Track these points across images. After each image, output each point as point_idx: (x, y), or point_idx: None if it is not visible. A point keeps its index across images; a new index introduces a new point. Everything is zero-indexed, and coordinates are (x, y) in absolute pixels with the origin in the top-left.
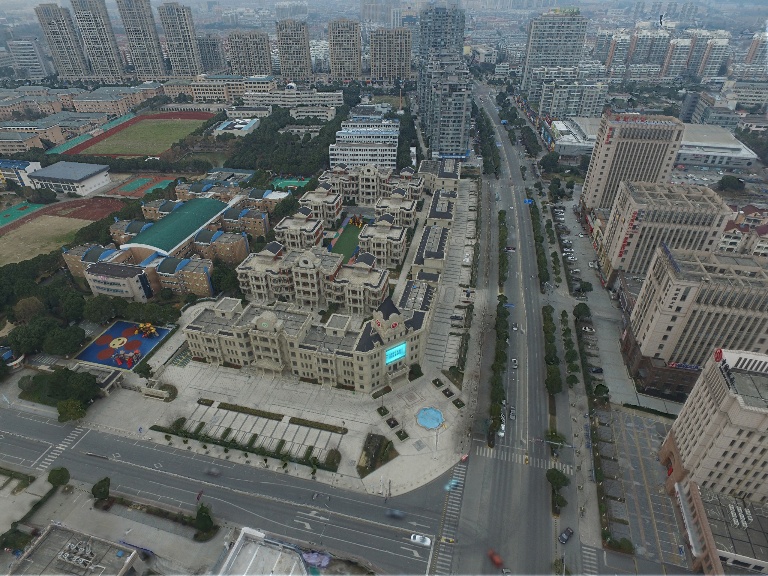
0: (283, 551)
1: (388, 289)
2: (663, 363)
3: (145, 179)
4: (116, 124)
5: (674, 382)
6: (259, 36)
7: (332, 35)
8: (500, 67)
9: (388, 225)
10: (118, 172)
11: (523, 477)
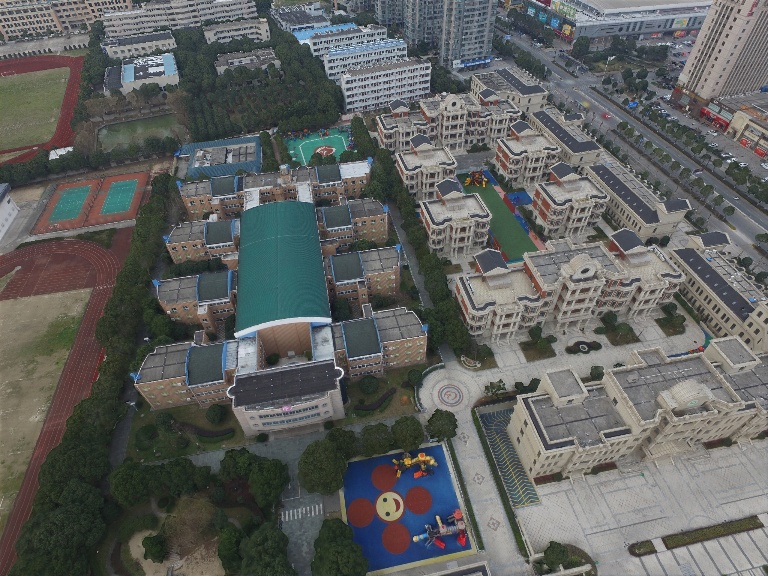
0: None
1: None
2: None
3: (77, 190)
4: None
5: None
6: None
7: None
8: None
9: (575, 178)
10: (11, 188)
11: None
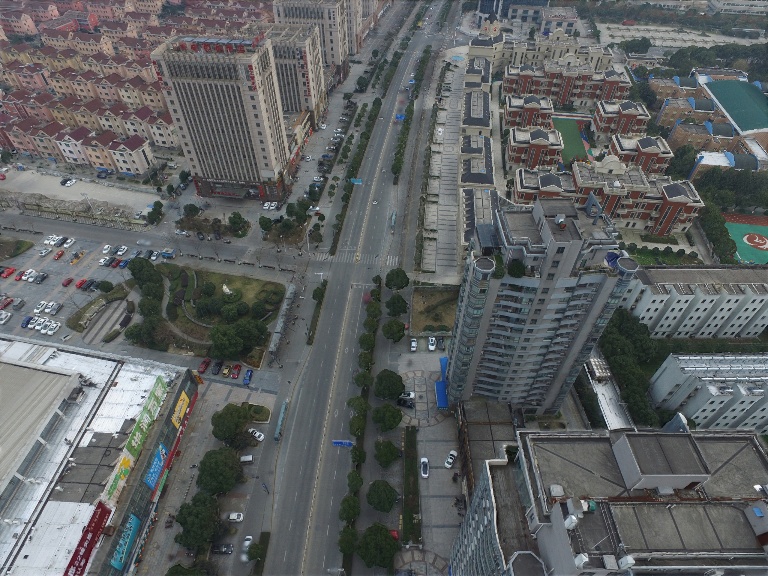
0: None
1: None
2: None
3: None
4: None
5: None
6: None
7: None
8: None
9: None
10: None
11: (417, 49)
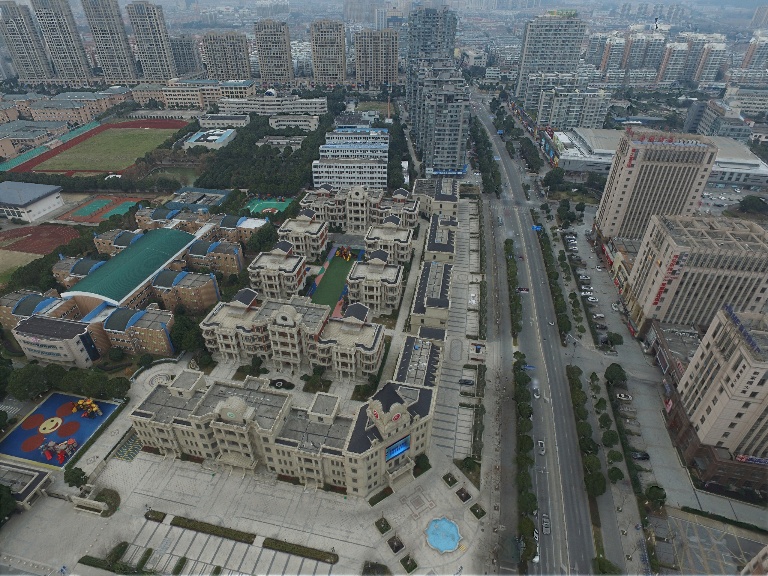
0: None
1: (384, 346)
2: (728, 454)
3: (104, 201)
4: (77, 134)
5: (741, 477)
6: (236, 37)
7: (314, 37)
8: (491, 71)
9: (381, 263)
10: (74, 192)
11: None
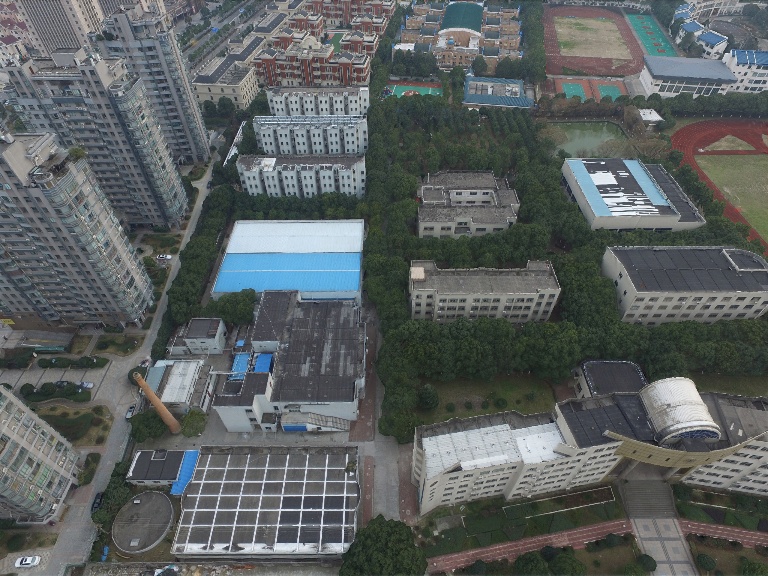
0: None
1: None
2: None
3: None
4: None
5: None
6: None
7: None
8: None
9: None
10: None
11: None
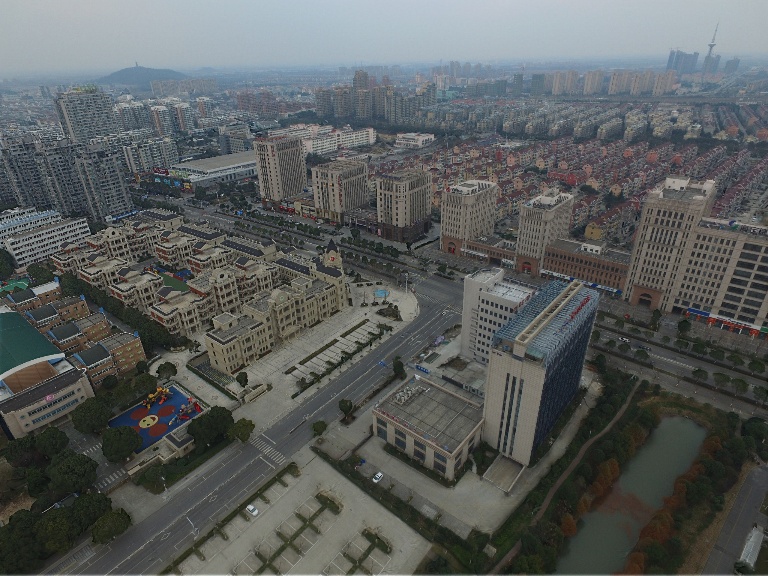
0: (477, 275)
1: None
2: None
3: None
4: None
5: (416, 232)
6: None
7: None
8: None
9: (209, 247)
10: None
11: (432, 281)
